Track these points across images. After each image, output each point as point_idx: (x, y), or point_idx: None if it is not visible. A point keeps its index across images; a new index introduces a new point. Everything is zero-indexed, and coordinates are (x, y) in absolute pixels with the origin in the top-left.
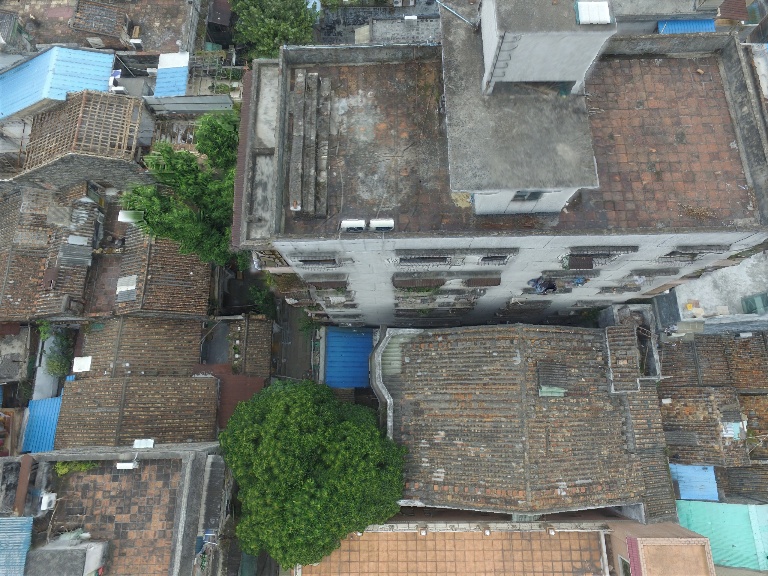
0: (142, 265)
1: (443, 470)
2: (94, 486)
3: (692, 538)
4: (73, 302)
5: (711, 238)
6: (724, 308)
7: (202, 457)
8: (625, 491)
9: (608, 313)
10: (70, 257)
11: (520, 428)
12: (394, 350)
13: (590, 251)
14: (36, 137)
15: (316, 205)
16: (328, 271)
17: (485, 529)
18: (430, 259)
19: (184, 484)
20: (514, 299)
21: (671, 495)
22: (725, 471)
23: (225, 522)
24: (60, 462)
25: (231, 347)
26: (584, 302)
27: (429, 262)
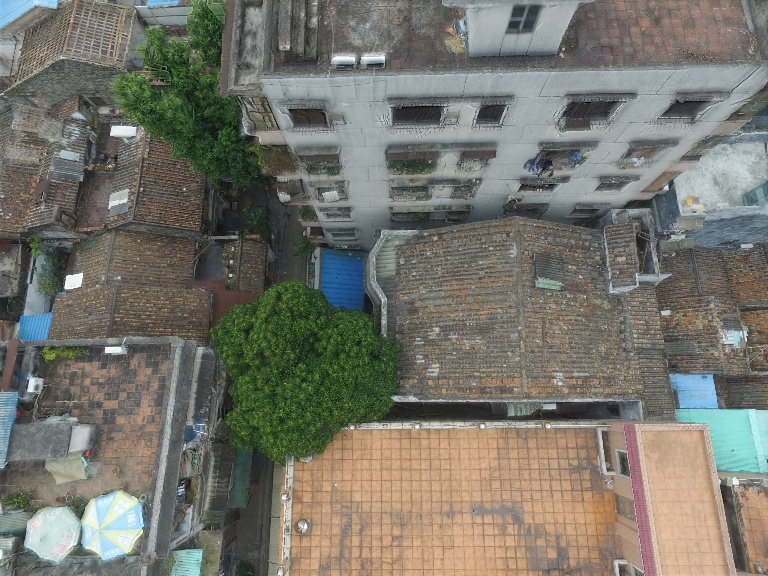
0: (134, 179)
1: (438, 365)
2: (82, 373)
3: (691, 424)
4: (64, 215)
5: (711, 79)
6: (725, 204)
7: (192, 345)
8: (623, 387)
9: (607, 219)
10: (61, 171)
11: (516, 318)
12: (389, 253)
13: (587, 98)
14: (27, 50)
15: (306, 50)
16: (319, 136)
17: (480, 423)
18: (423, 120)
19: (173, 367)
20: (511, 196)
21: (670, 396)
22: (725, 384)
23: (216, 425)
24: (47, 347)
25: (225, 268)
26: (582, 205)
27: (422, 124)
